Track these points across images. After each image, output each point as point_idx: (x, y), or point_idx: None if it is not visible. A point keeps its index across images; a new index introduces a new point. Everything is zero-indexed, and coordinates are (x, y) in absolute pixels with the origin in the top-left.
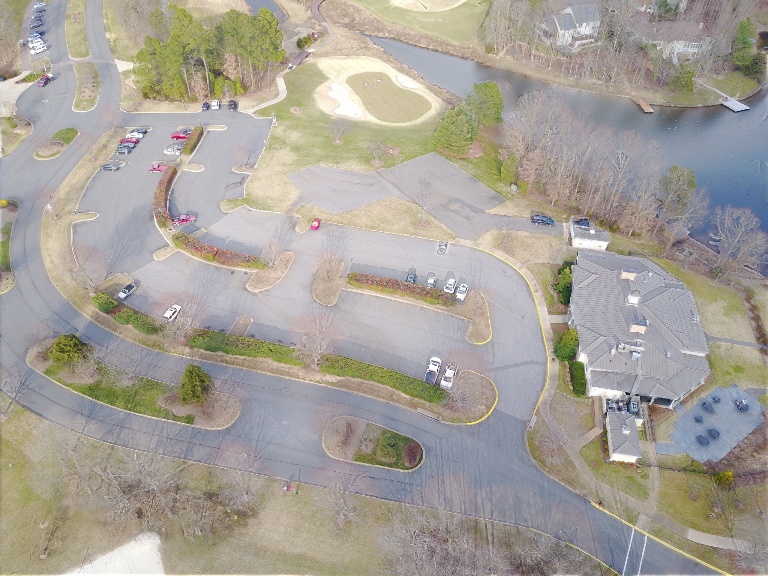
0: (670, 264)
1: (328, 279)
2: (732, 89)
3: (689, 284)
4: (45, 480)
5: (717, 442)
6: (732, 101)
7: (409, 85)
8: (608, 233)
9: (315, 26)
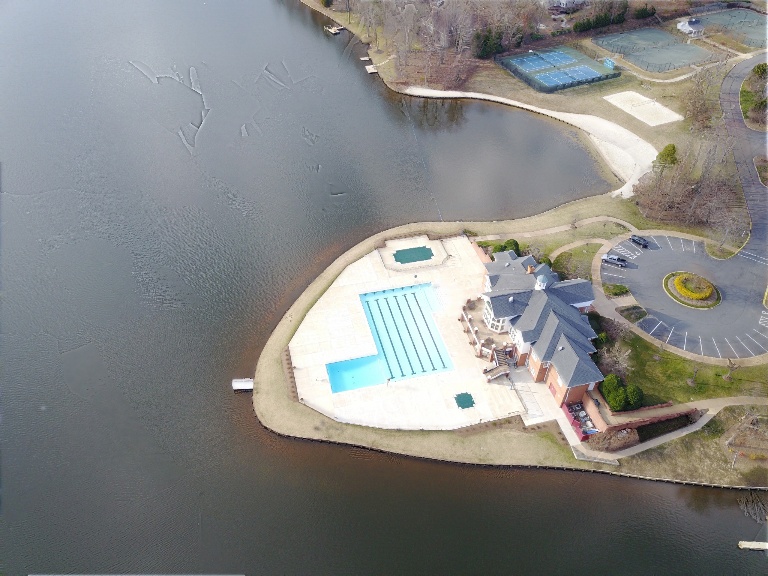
0: None
1: None
2: None
3: None
4: None
5: None
6: None
7: None
8: None
9: None
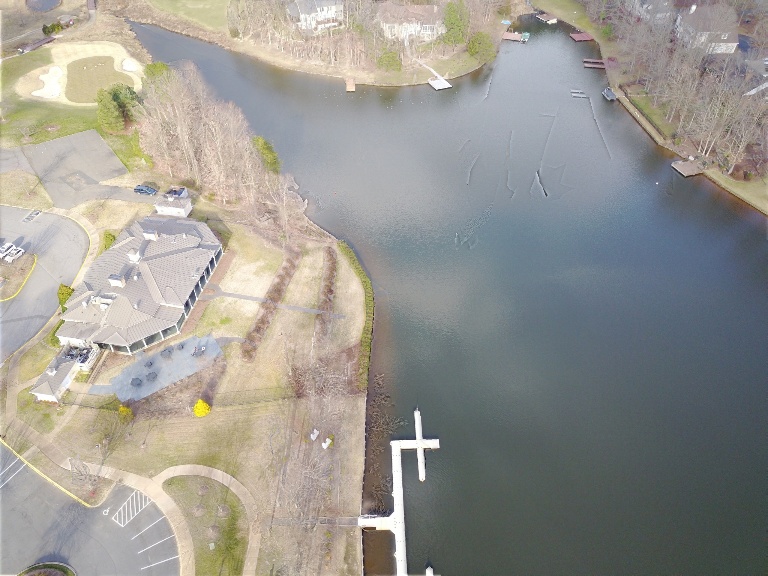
0: (240, 229)
1: None
2: (448, 69)
3: (243, 246)
4: None
5: (151, 384)
6: (439, 80)
7: (130, 68)
8: (189, 200)
9: (80, 13)
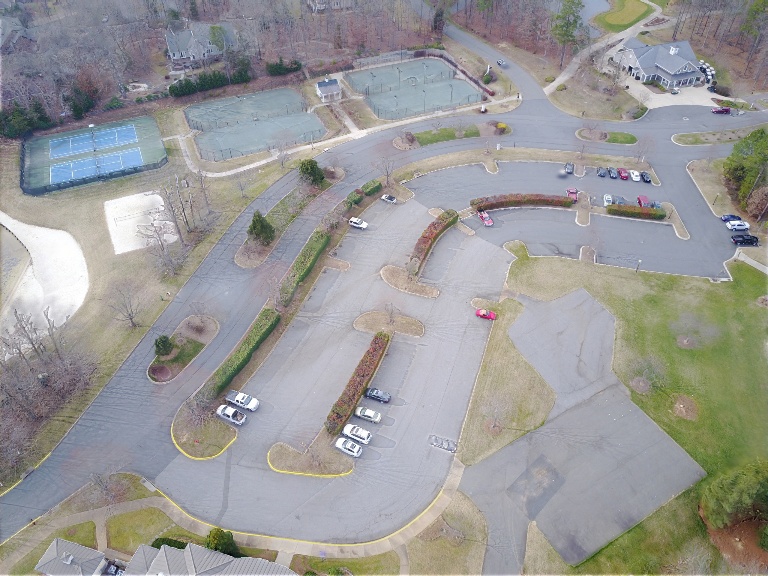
0: None
1: (389, 322)
2: None
3: None
4: (232, 193)
5: None
6: None
7: None
8: None
9: None
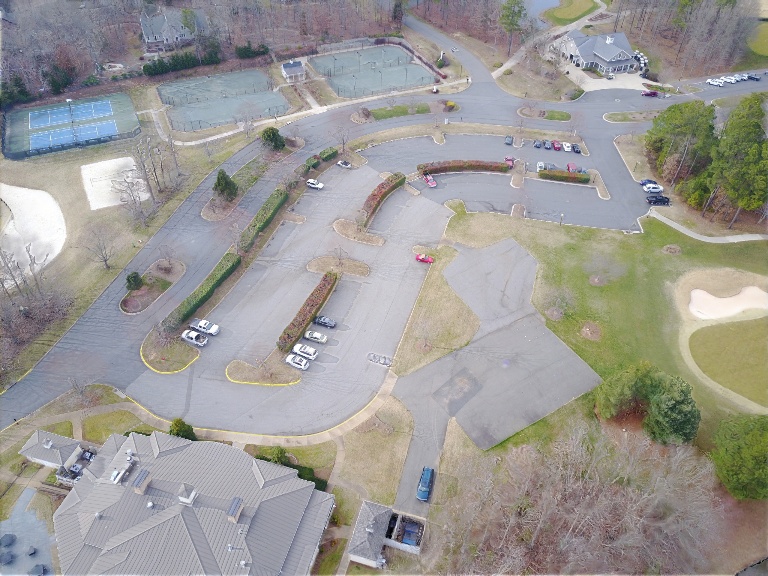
0: None
1: (339, 264)
2: None
3: None
4: (200, 159)
5: None
6: None
7: None
8: (370, 557)
9: None
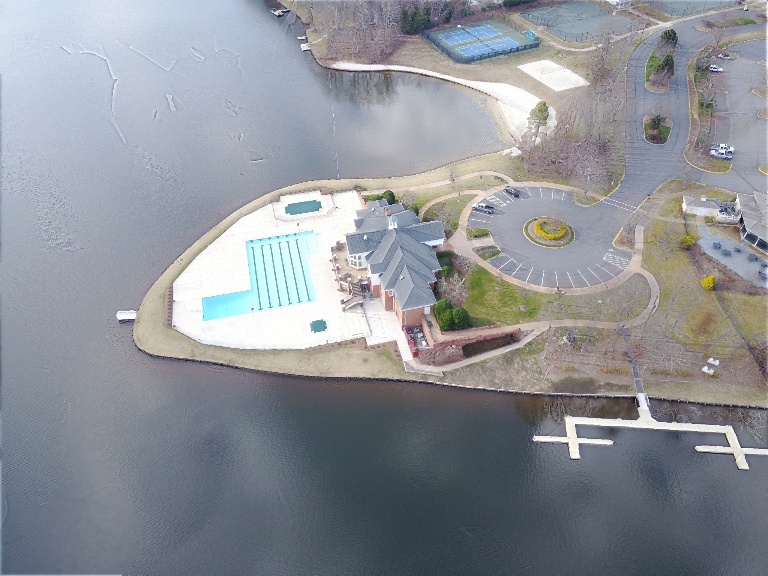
0: None
1: None
2: None
3: None
4: None
5: (720, 254)
6: None
7: None
8: None
9: None
